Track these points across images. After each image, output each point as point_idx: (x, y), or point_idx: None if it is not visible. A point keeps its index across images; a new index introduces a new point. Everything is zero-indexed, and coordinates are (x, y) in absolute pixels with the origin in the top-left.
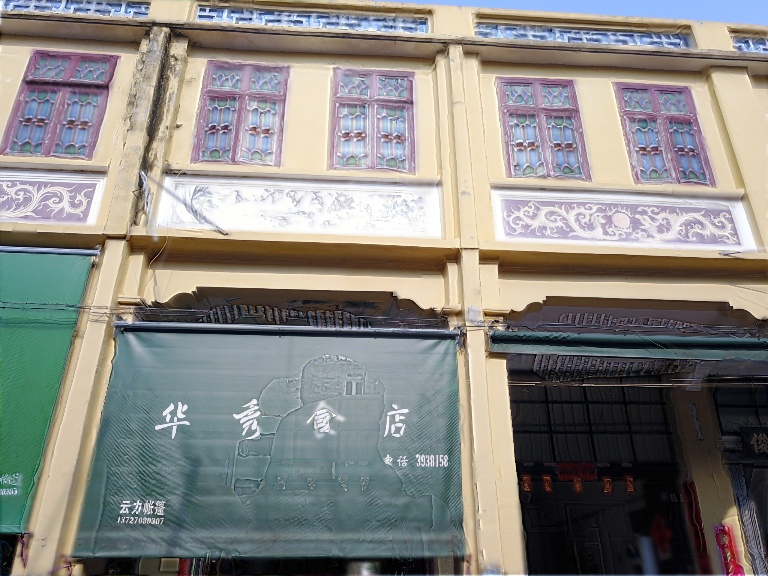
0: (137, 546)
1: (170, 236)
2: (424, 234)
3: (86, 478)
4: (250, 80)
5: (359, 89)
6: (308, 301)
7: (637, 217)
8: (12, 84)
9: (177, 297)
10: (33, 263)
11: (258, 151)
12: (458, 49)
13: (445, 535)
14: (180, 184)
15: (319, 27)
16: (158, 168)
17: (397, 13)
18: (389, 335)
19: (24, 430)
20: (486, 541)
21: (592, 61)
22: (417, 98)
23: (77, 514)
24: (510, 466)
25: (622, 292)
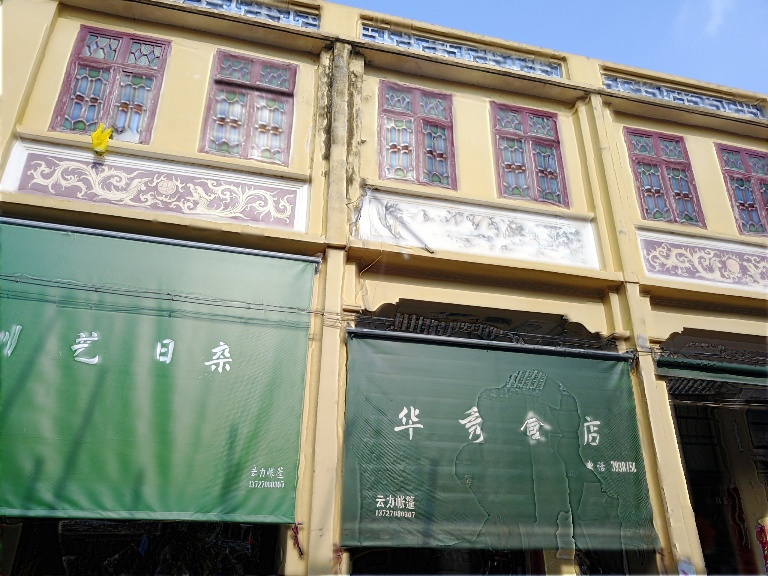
0: (397, 537)
1: (384, 250)
2: (584, 265)
3: (340, 474)
4: (419, 104)
5: (513, 124)
6: (456, 314)
7: (744, 264)
8: (200, 80)
9: (383, 307)
10: (262, 266)
11: (437, 174)
12: (598, 98)
13: (548, 529)
14: (372, 198)
15: (470, 59)
16: (357, 182)
17: (536, 55)
18: (576, 355)
19: (280, 427)
20: (677, 536)
21: (699, 122)
22: (562, 138)
23: (339, 507)
24: (681, 473)
25: (740, 328)
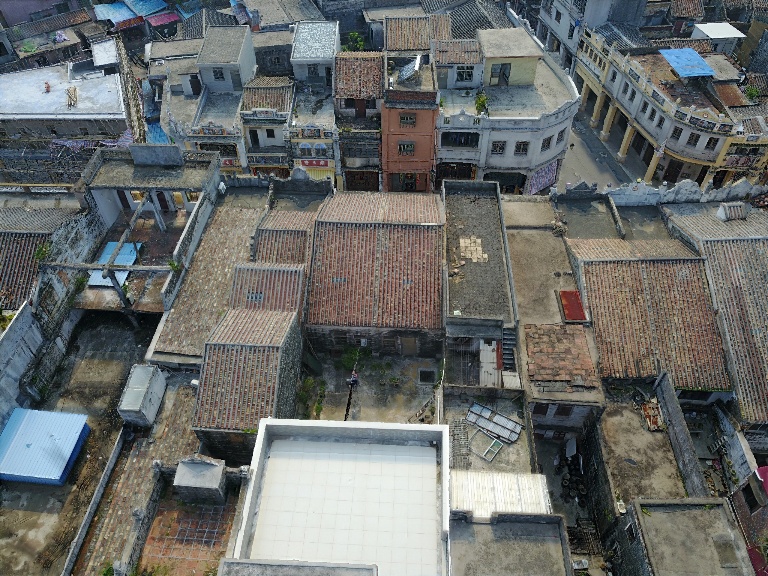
0: None
1: None
2: None
3: None
4: None
5: None
6: None
7: None
8: None
9: None
10: None
11: None
12: None
13: None
14: None
15: (4, 188)
16: None
17: None
18: None
19: None
20: None
21: None
22: None
23: None
24: None
25: None
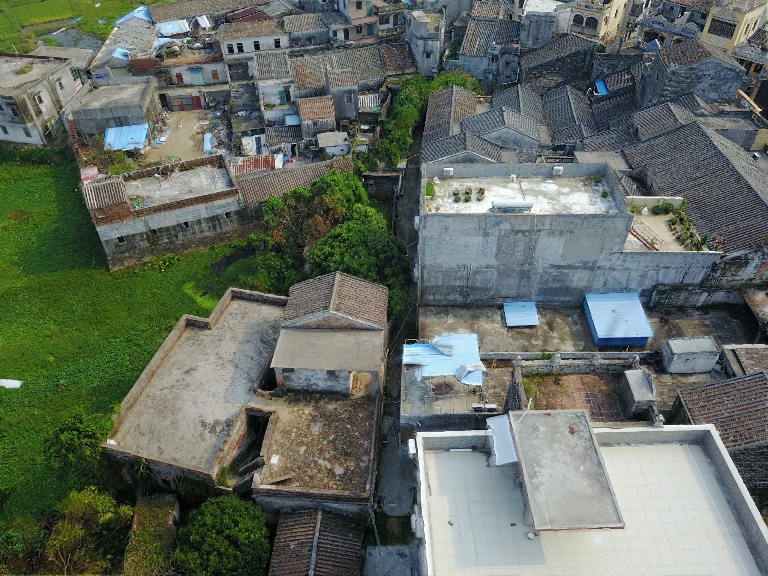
0: None
1: None
2: None
3: None
4: None
5: None
6: None
7: None
8: None
9: None
10: None
11: None
12: None
13: None
14: None
15: None
16: None
17: None
18: None
19: None
20: None
21: None
22: None
23: None
24: None
25: None
